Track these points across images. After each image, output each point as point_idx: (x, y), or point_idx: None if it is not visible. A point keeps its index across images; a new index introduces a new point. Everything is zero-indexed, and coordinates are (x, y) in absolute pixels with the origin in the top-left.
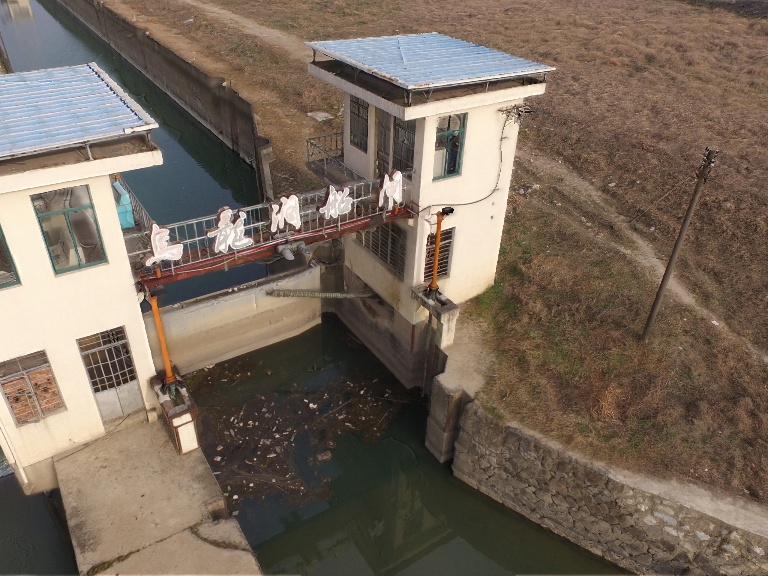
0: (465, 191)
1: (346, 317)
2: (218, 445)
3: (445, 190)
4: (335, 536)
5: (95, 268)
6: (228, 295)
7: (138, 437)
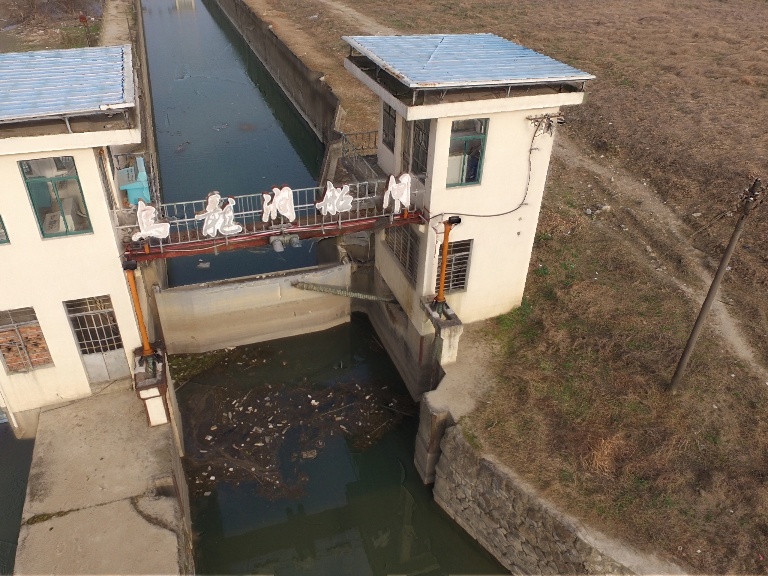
0: (486, 202)
1: (374, 319)
2: (213, 425)
3: (461, 198)
4: (335, 537)
5: (80, 236)
6: (253, 281)
7: (119, 403)
